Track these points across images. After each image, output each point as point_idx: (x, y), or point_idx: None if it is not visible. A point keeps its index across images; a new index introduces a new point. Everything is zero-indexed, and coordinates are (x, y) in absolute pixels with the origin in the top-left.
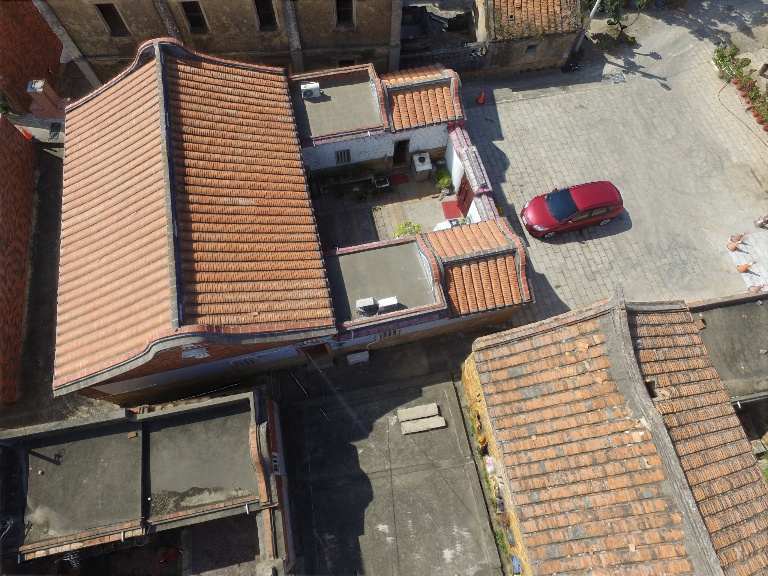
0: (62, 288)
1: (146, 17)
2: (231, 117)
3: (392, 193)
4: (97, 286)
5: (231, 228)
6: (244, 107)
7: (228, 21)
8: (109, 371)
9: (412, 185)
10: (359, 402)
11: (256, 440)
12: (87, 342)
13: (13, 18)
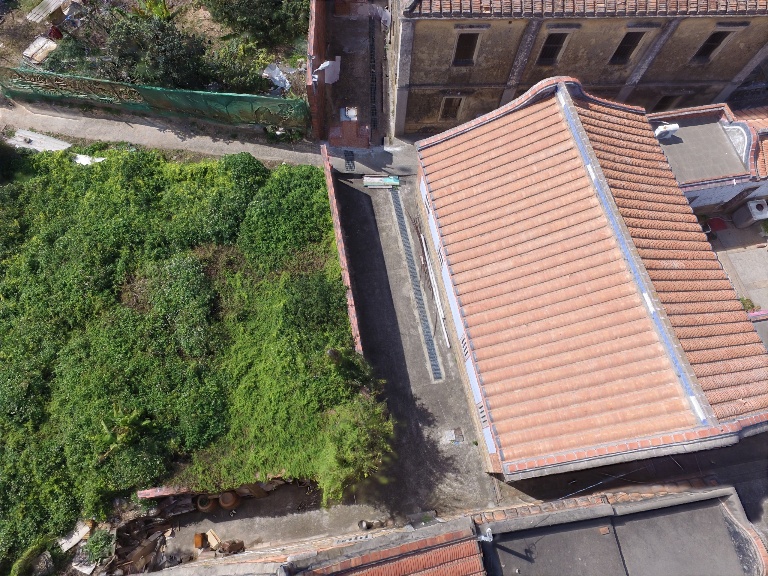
0: (480, 354)
1: (502, 48)
2: (629, 165)
3: (714, 240)
4: (535, 356)
5: (682, 297)
6: (633, 153)
7: (583, 54)
8: (590, 460)
9: (732, 232)
10: (741, 479)
11: (765, 547)
12: (542, 422)
13: (317, 39)
